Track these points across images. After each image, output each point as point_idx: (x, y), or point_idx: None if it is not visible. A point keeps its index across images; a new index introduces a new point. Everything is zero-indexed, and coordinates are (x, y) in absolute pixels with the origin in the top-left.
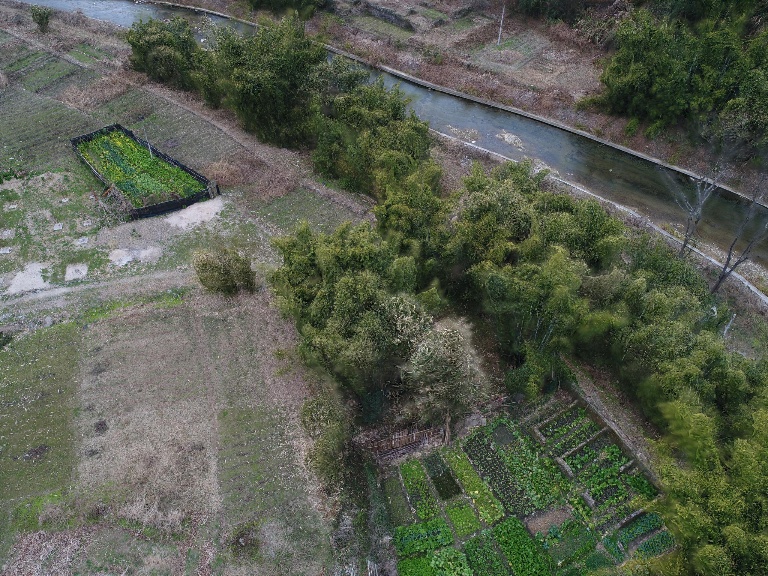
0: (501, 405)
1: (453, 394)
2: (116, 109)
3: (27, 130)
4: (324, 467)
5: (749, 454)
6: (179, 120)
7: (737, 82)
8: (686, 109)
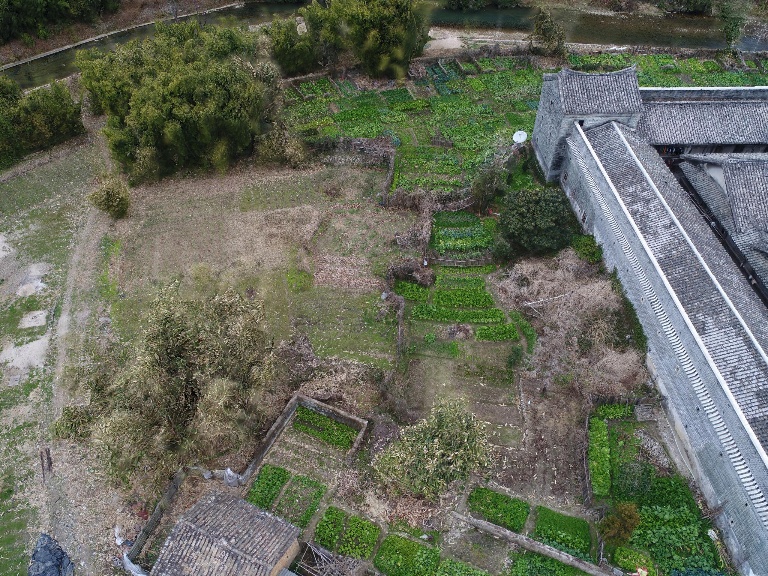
0: None
1: None
2: None
3: None
4: None
5: None
6: None
7: None
8: (47, 4)
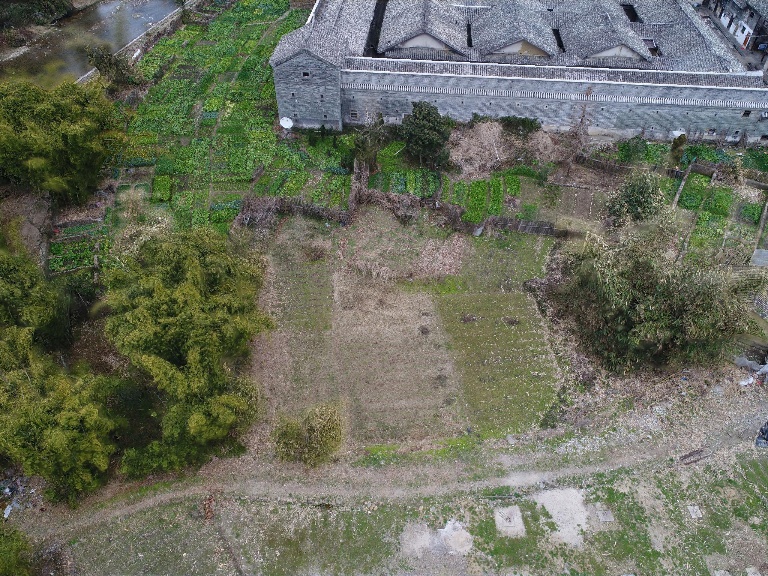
0: None
1: None
2: None
3: None
4: None
5: None
6: None
7: None
8: None
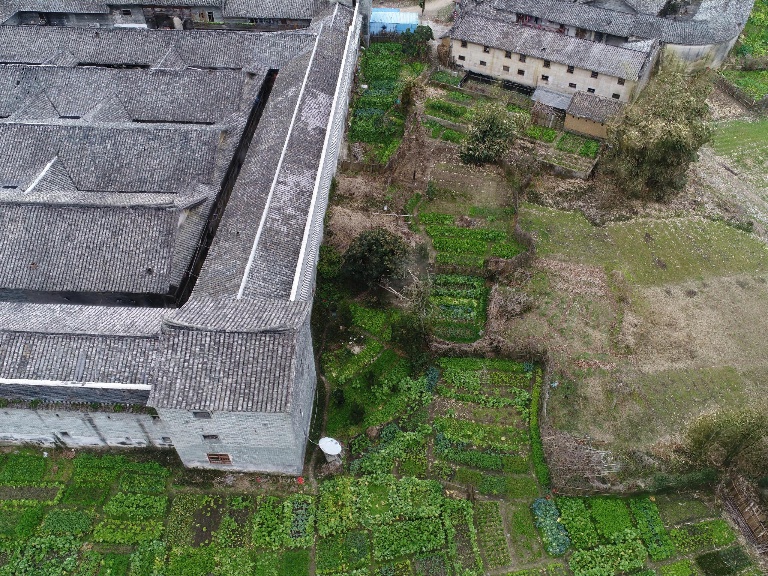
0: None
1: None
2: None
3: None
4: (697, 431)
5: None
6: None
7: None
8: None
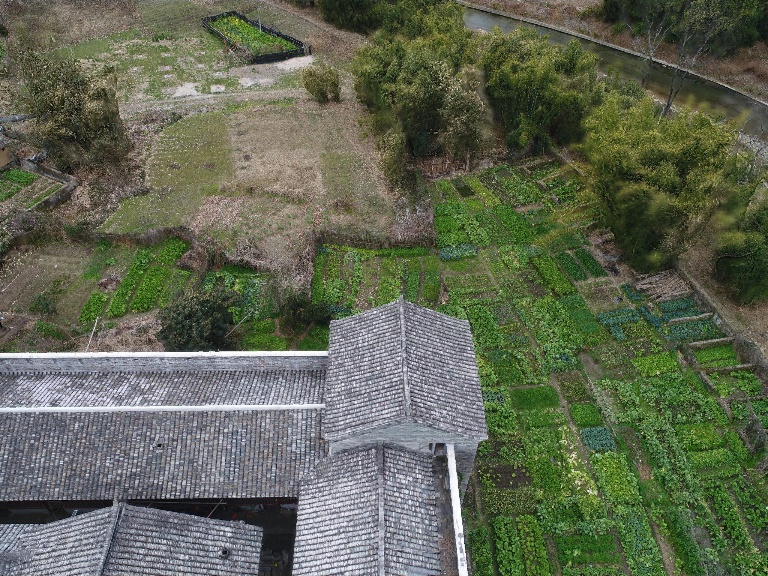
0: (503, 157)
1: (472, 125)
2: (229, 7)
3: (167, 15)
4: (390, 167)
5: (636, 115)
6: (276, 14)
7: None
8: (662, 12)
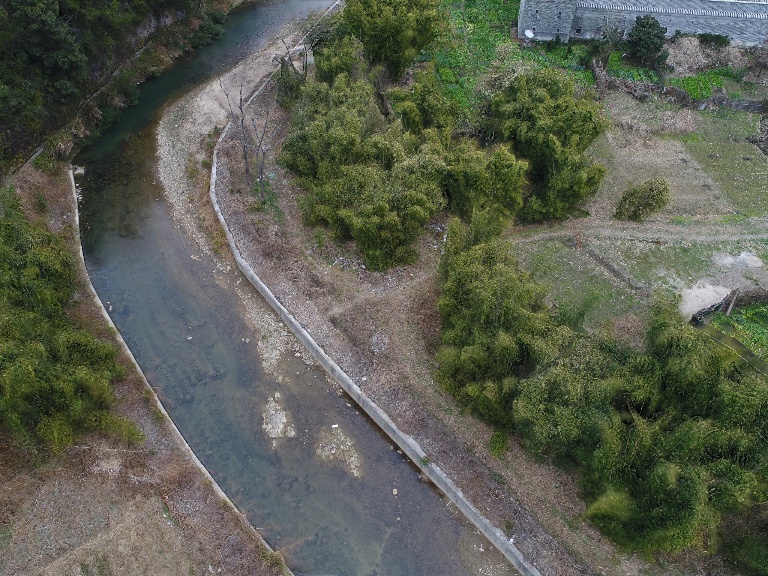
0: None
1: None
2: None
3: None
4: None
5: None
6: None
7: (8, 260)
8: None
